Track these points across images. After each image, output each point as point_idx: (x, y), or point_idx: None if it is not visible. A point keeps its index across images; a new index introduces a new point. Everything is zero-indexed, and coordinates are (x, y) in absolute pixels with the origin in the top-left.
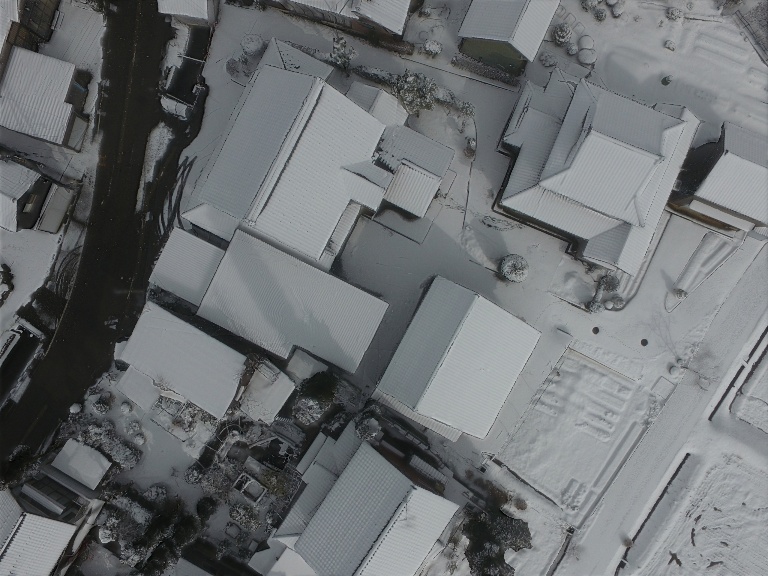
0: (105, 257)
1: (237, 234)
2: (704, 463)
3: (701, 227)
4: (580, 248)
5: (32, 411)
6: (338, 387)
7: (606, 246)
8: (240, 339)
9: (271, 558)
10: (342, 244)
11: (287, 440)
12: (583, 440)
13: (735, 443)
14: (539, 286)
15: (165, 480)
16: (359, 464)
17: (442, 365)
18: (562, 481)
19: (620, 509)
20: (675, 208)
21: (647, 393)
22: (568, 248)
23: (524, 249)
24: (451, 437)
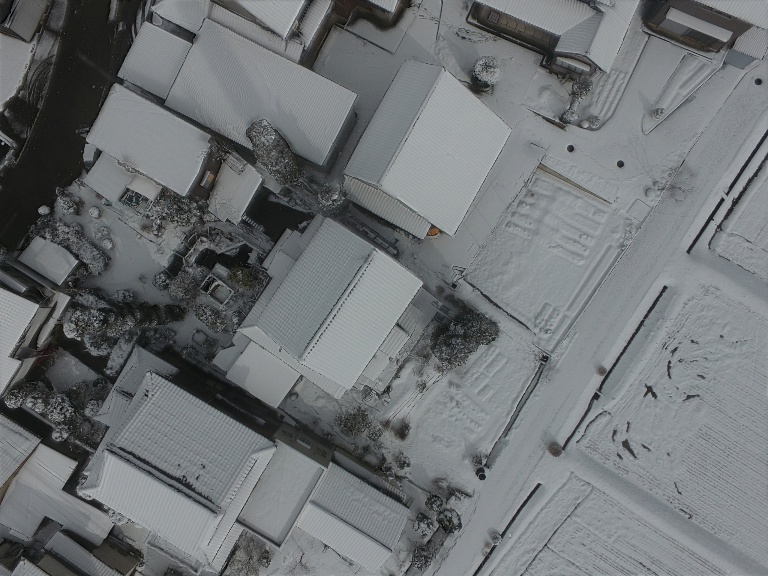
0: (77, 66)
1: (206, 23)
2: (681, 293)
3: (680, 48)
4: (554, 53)
5: (2, 218)
6: (304, 172)
7: (578, 38)
8: (207, 129)
9: (235, 354)
10: (312, 39)
11: (255, 246)
12: (557, 263)
13: (713, 273)
14: (513, 99)
15: (133, 287)
16: (322, 238)
17: (407, 140)
18: (535, 305)
19: (594, 337)
20: (653, 29)
21: (623, 216)
22: (543, 60)
23: (498, 61)
24: (419, 233)
